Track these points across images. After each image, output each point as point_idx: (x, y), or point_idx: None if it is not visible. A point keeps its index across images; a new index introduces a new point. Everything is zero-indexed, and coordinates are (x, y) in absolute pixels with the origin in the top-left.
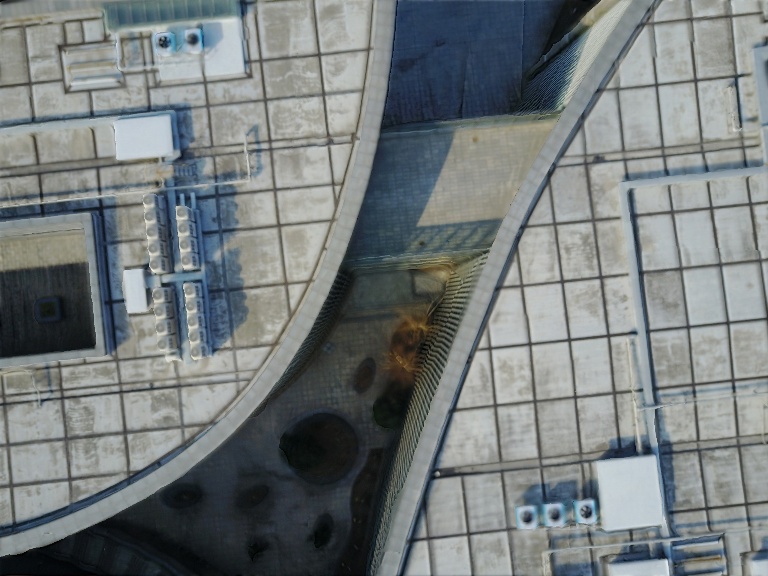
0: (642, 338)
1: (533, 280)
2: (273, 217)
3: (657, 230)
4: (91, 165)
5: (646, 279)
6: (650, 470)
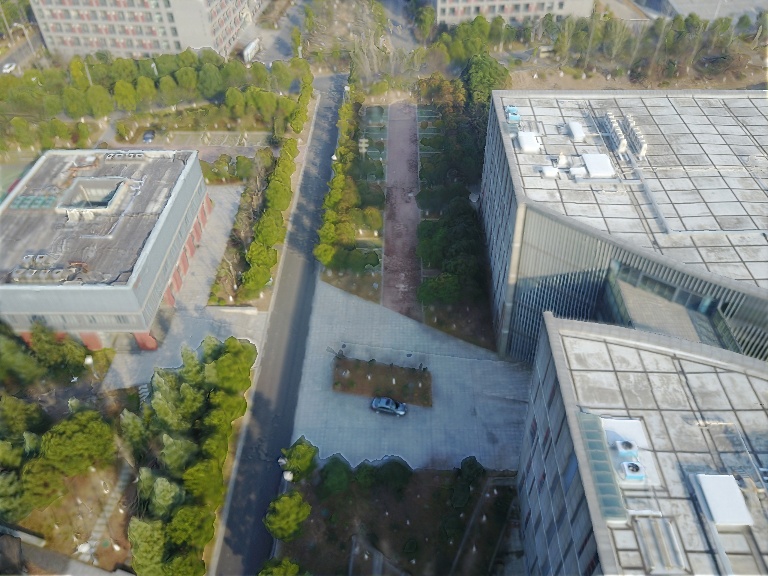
0: (766, 232)
1: (748, 274)
2: (759, 413)
3: (693, 223)
4: (761, 561)
5: (726, 229)
6: None
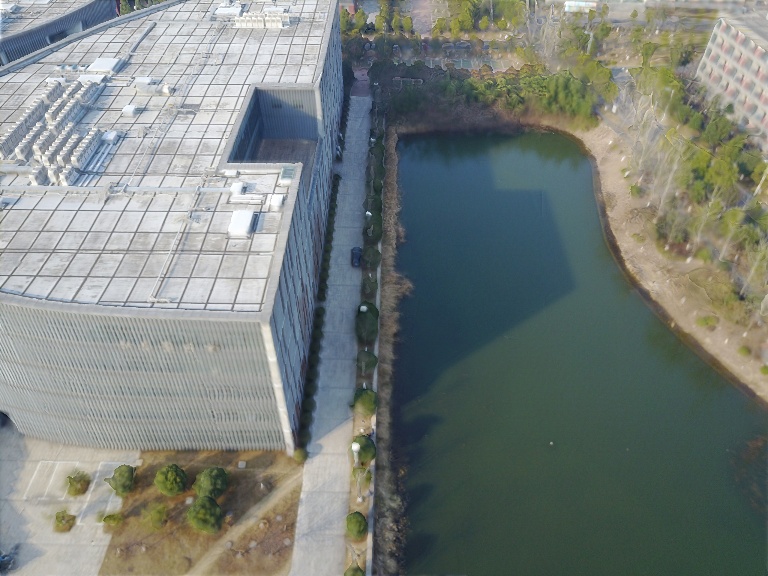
0: None
1: None
2: None
3: None
4: None
5: None
6: (115, 60)
